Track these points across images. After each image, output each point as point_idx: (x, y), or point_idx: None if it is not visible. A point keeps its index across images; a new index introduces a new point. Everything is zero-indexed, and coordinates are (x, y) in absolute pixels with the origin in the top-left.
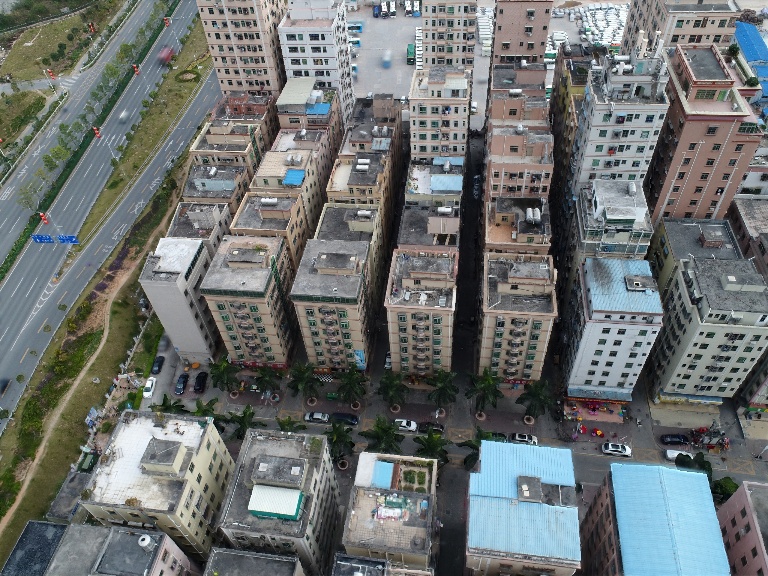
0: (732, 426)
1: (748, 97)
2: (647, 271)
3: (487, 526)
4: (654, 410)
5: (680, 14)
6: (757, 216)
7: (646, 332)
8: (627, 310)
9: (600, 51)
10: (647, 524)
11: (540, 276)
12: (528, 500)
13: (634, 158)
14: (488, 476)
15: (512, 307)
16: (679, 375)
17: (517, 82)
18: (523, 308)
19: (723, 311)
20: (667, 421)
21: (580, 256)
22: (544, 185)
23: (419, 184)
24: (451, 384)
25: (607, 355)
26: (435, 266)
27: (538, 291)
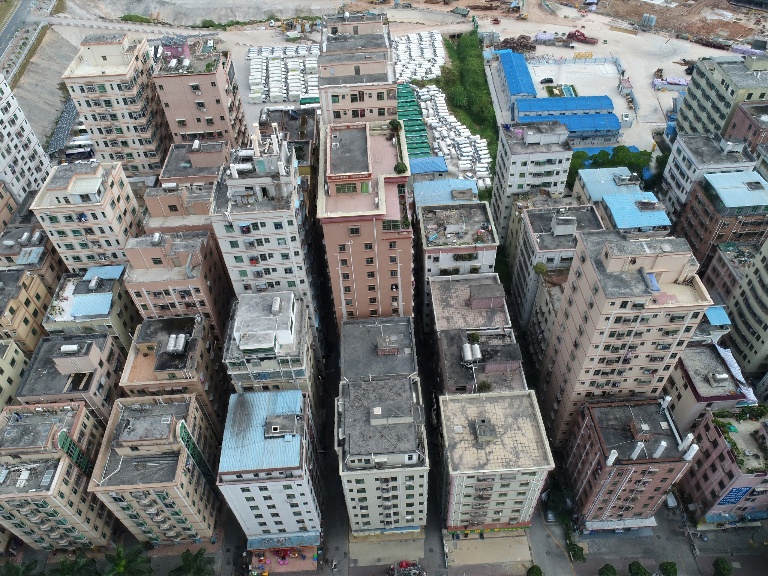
0: (435, 553)
1: (402, 184)
2: (295, 406)
3: None
4: (353, 545)
5: (331, 89)
6: (452, 302)
7: (290, 486)
8: (258, 467)
9: (310, 114)
10: None
11: (157, 435)
12: None
13: (283, 265)
14: None
15: (131, 476)
16: (356, 515)
17: (194, 166)
18: (144, 475)
19: (363, 456)
20: (366, 558)
21: (236, 386)
22: (199, 300)
23: (67, 305)
24: (91, 567)
25: (266, 508)
26: (31, 436)
27: (166, 448)
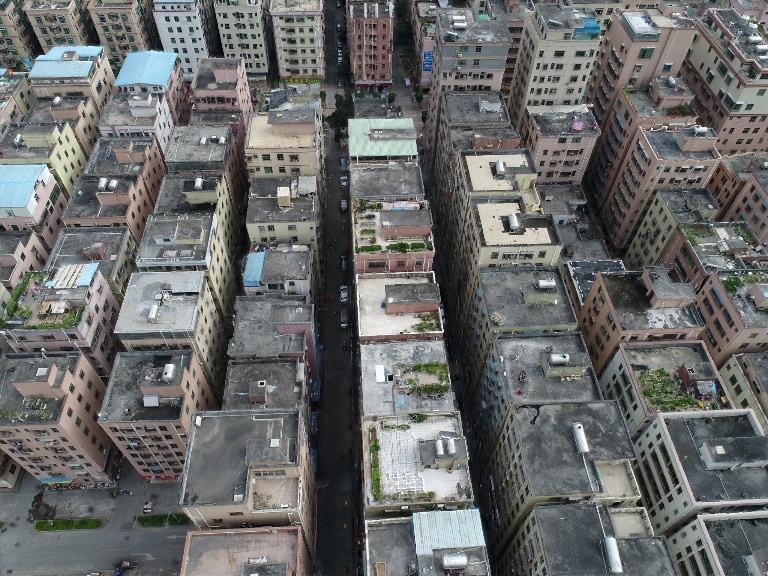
0: None
1: None
2: None
3: (41, 70)
4: None
5: None
6: None
7: (190, 18)
8: (173, 1)
9: None
10: (134, 69)
11: None
12: (66, 59)
13: None
14: (49, 55)
15: None
16: (228, 55)
17: None
18: None
19: None
20: None
21: None
22: None
23: None
24: None
25: (179, 42)
26: None
27: None
